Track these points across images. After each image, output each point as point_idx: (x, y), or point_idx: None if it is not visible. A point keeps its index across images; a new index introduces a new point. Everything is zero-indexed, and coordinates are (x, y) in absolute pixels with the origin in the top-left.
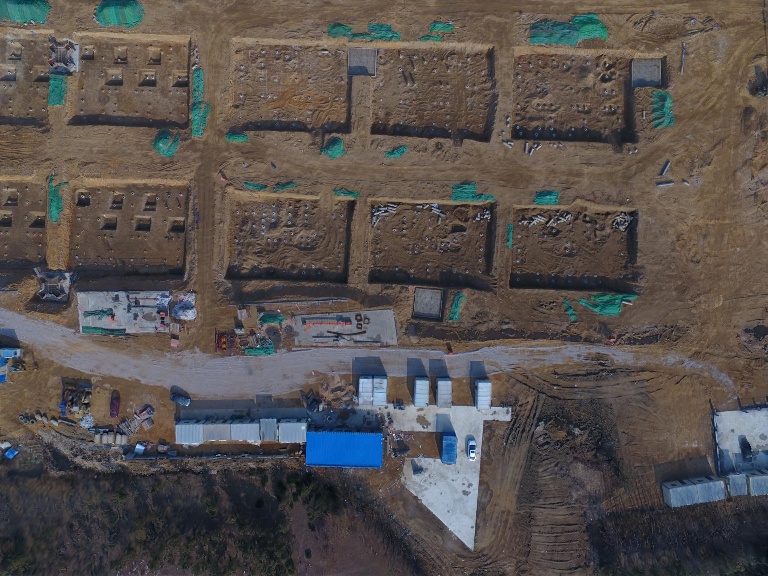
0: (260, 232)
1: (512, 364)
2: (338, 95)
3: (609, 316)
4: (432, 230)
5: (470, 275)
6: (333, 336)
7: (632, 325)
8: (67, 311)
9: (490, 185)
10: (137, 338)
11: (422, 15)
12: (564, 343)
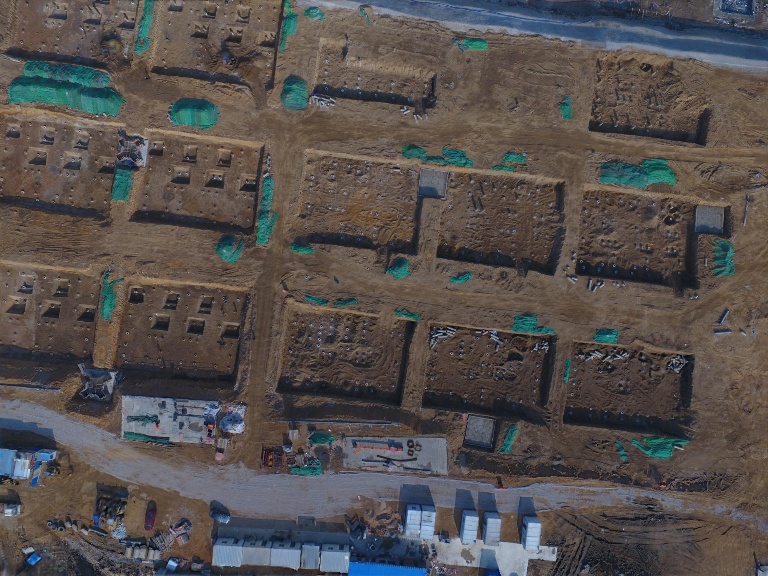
0: (315, 345)
1: (561, 502)
2: (406, 214)
3: (660, 459)
4: (489, 356)
5: (523, 405)
6: (383, 461)
7: (682, 470)
8: (110, 414)
9: (551, 318)
10: (180, 448)
11: (497, 144)
12: (614, 485)
